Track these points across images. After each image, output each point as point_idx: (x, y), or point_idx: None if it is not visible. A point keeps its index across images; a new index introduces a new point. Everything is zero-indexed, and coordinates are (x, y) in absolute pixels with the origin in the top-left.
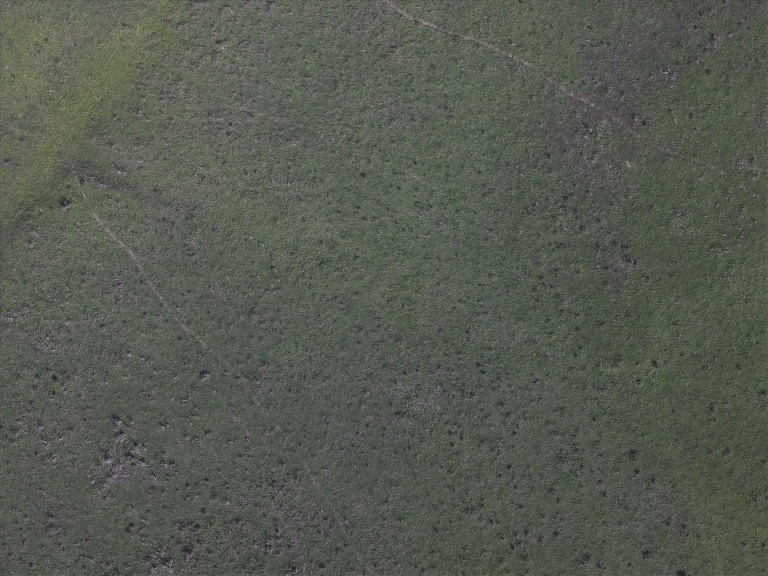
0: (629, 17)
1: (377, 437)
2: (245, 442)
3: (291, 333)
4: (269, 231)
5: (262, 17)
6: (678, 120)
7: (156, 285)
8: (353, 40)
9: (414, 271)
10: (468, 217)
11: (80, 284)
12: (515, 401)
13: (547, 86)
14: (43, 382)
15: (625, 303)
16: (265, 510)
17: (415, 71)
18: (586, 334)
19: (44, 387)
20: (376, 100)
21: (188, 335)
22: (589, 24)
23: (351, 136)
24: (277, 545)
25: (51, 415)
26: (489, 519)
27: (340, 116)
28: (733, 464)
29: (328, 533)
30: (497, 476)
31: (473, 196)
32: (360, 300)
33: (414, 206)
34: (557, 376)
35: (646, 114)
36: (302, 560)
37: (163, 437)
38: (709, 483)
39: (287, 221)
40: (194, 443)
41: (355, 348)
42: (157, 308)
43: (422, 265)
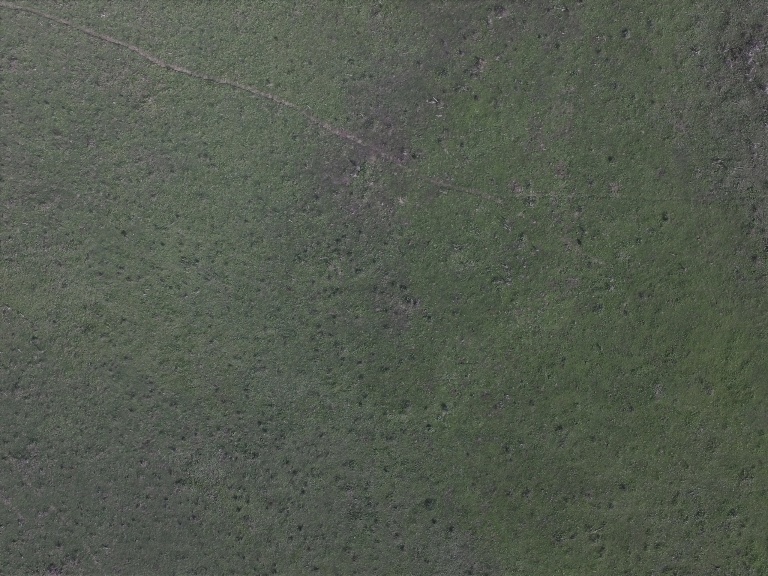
0: (391, 47)
1: (159, 508)
2: (18, 526)
3: (59, 406)
4: (28, 300)
5: (5, 76)
6: (449, 150)
7: None
8: (103, 93)
9: (185, 330)
10: (238, 269)
11: None
12: (301, 458)
13: (311, 125)
14: None
15: (408, 346)
16: None
17: (171, 120)
18: (370, 381)
19: None
20: (132, 154)
21: None
22: (350, 57)
23: (108, 194)
24: None
25: None
26: None
27: (95, 173)
28: (534, 504)
29: None
30: (288, 538)
31: (241, 246)
32: (130, 365)
33: (180, 262)
34: (343, 428)
35: (416, 147)
36: None
37: None
38: (510, 527)
39: (47, 288)
40: None
41: (128, 416)
42: None
43: (193, 323)
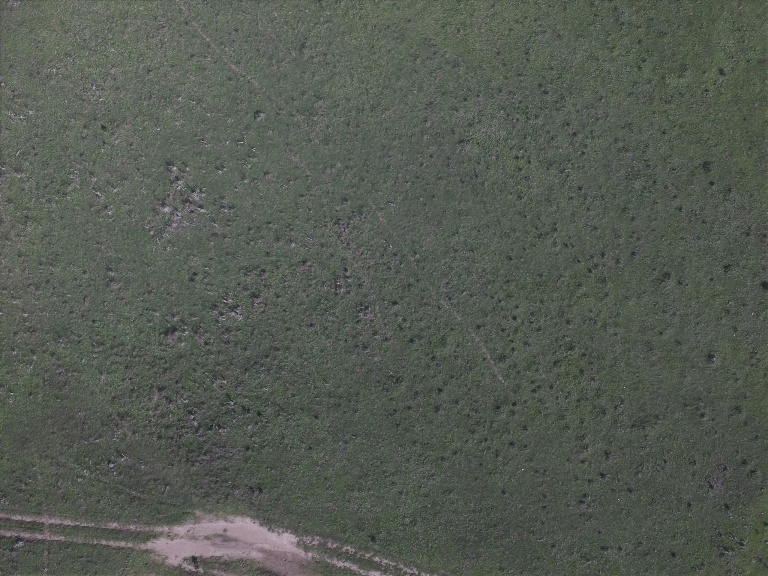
0: None
1: (442, 168)
2: (306, 181)
3: (345, 67)
4: None
5: None
6: None
7: (202, 26)
8: None
9: None
10: None
11: (123, 30)
12: (581, 121)
13: None
14: (92, 134)
15: (687, 12)
16: (332, 250)
17: None
18: (649, 46)
19: (93, 139)
20: None
21: (239, 75)
22: None
23: None
24: (347, 285)
25: (103, 167)
26: (564, 243)
27: None
28: None
29: (399, 269)
30: (569, 199)
31: None
32: (414, 28)
33: None
34: (623, 92)
35: None
36: (374, 299)
37: (221, 182)
38: None
39: None
40: (253, 186)
41: (412, 78)
42: (205, 50)
43: None
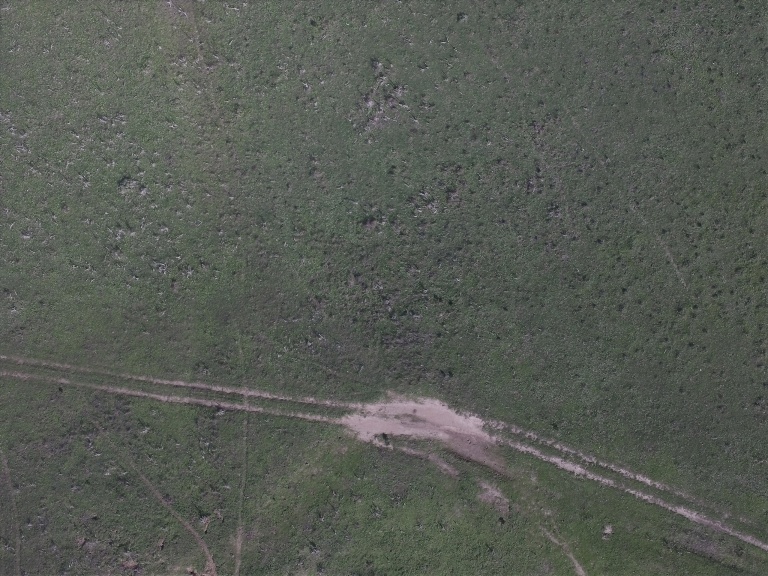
0: None
1: (636, 76)
2: (504, 83)
3: None
4: None
5: None
6: None
7: None
8: None
9: None
10: None
11: None
12: None
13: None
14: (302, 28)
15: None
16: (526, 150)
17: None
18: None
19: (303, 33)
20: None
21: None
22: None
23: None
24: (539, 185)
25: (311, 60)
26: (750, 155)
27: None
28: None
29: (589, 172)
30: (757, 112)
31: None
32: None
33: None
34: None
35: None
36: (564, 199)
37: (422, 80)
38: None
39: None
40: (453, 85)
41: None
42: None
43: None
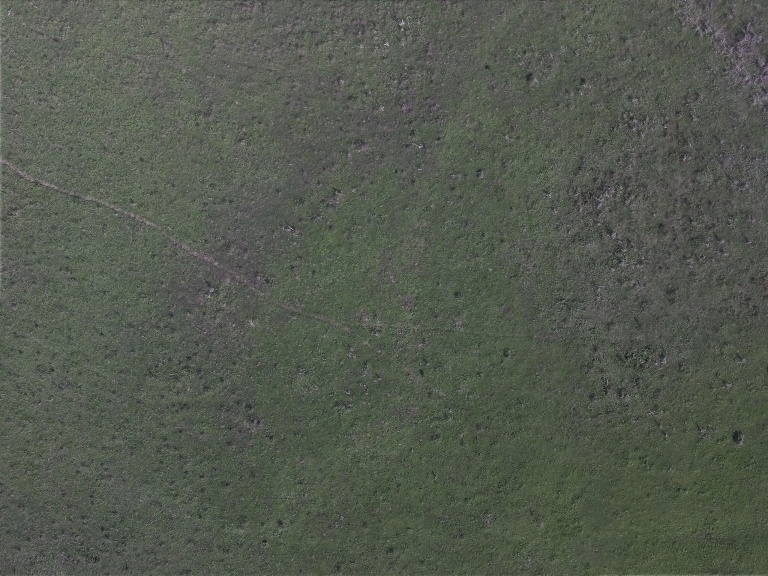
0: (252, 174)
1: None
2: None
3: None
4: None
5: None
6: (301, 277)
7: None
8: None
9: (37, 435)
10: (91, 380)
11: None
12: (141, 565)
13: (170, 245)
14: None
15: (250, 463)
16: None
17: (36, 233)
18: (211, 496)
19: None
20: None
21: None
22: (212, 182)
23: None
24: None
25: None
26: None
27: None
28: None
29: None
30: None
31: (96, 358)
32: None
33: (36, 370)
34: (183, 539)
35: (270, 271)
36: None
37: None
38: None
39: None
40: None
41: None
42: None
43: (45, 429)
